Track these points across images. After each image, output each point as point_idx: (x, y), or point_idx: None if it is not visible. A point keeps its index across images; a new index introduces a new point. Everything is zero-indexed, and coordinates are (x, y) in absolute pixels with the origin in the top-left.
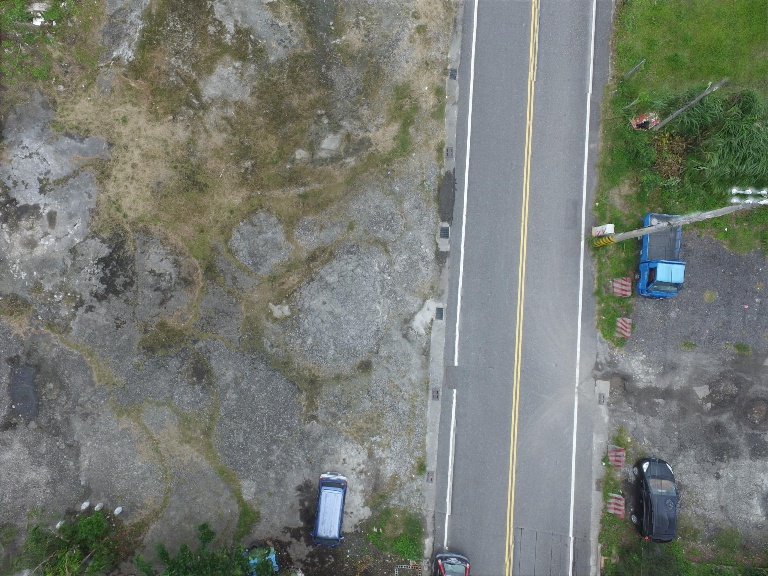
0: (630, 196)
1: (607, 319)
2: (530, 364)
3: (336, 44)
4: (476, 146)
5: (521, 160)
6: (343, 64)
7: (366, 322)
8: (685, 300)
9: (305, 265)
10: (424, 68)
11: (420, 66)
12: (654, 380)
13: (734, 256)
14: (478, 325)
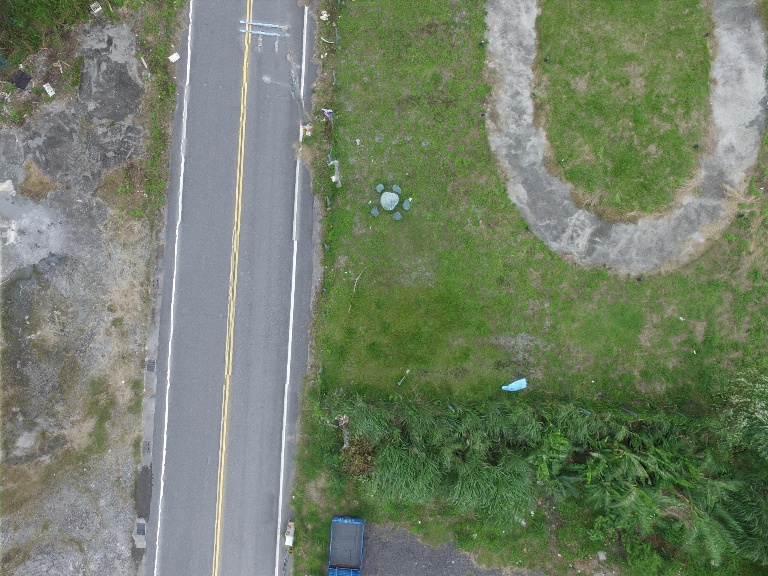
0: (324, 491)
1: None
2: None
3: (31, 339)
4: (173, 440)
5: (216, 455)
6: (38, 359)
7: None
8: None
9: None
10: (121, 361)
11: (116, 360)
12: None
13: (427, 549)
14: None
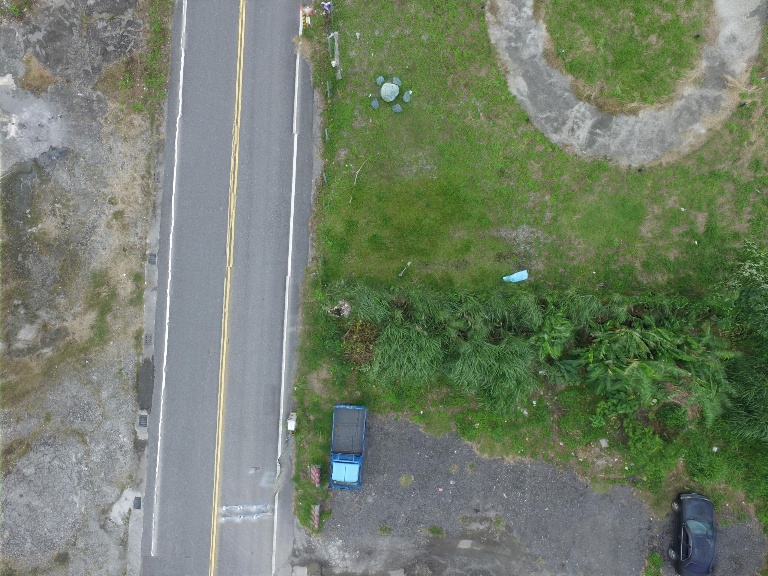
0: (326, 381)
1: (303, 505)
2: (226, 553)
3: (32, 232)
4: (174, 333)
5: (218, 347)
6: (40, 252)
7: (63, 514)
8: (381, 484)
9: (2, 458)
10: (122, 254)
11: (118, 253)
12: (350, 565)
13: (429, 439)
14: (175, 514)
